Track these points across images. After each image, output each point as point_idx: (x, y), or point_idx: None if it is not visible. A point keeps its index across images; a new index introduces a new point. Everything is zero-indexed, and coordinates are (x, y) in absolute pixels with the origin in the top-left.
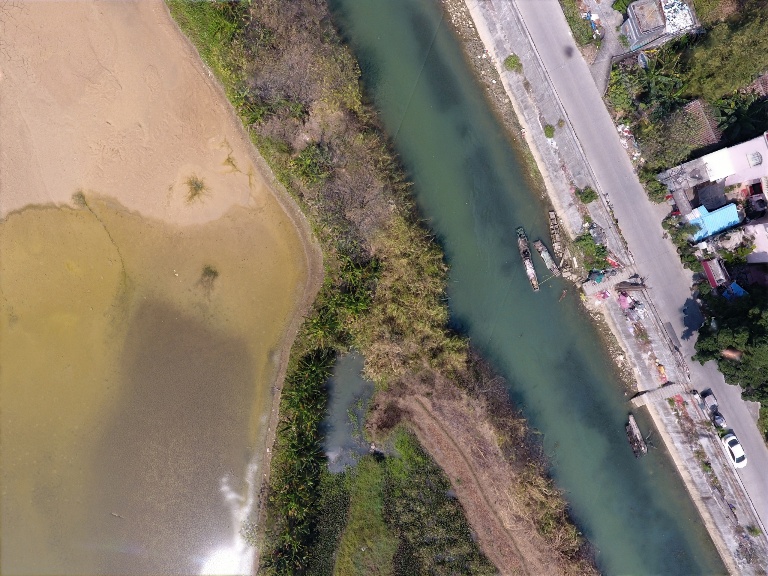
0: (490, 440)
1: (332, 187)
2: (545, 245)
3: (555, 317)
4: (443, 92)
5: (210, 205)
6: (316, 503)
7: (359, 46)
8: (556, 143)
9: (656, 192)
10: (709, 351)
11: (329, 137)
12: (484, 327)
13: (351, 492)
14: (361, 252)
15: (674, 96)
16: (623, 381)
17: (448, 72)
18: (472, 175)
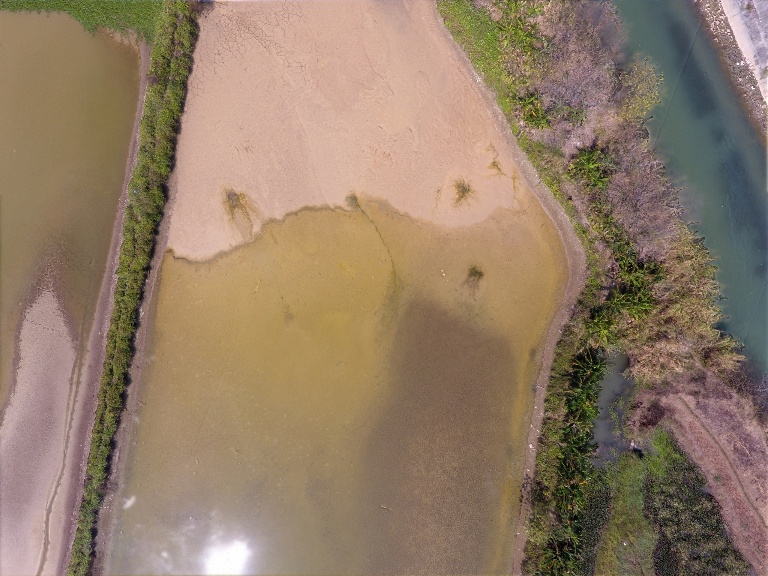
0: (758, 438)
1: None
2: None
3: None
4: (701, 98)
5: (476, 207)
6: None
7: None
8: None
9: None
10: None
11: (605, 142)
12: (740, 328)
13: (612, 488)
14: None
15: None
16: None
17: (705, 78)
18: (728, 179)
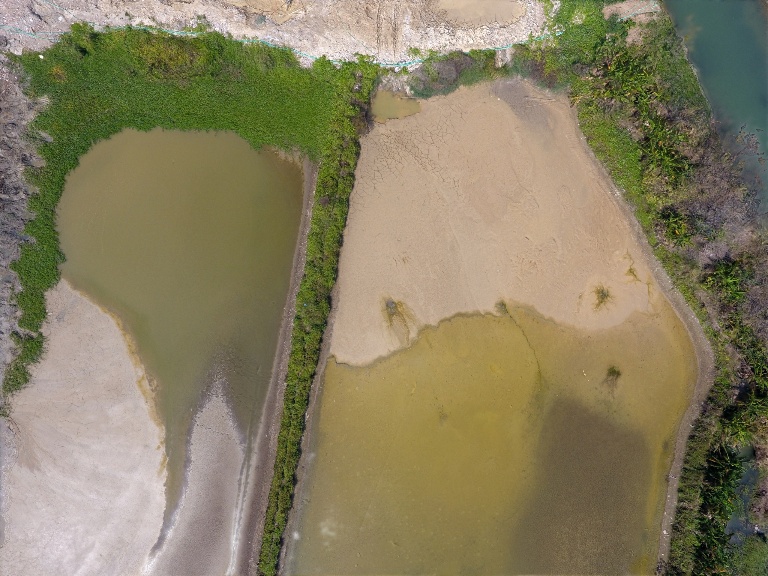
0: None
1: None
2: None
3: None
4: None
5: (614, 311)
6: None
7: (745, 168)
8: None
9: None
10: None
11: (738, 255)
12: None
13: (739, 569)
14: None
15: None
16: None
17: None
18: None
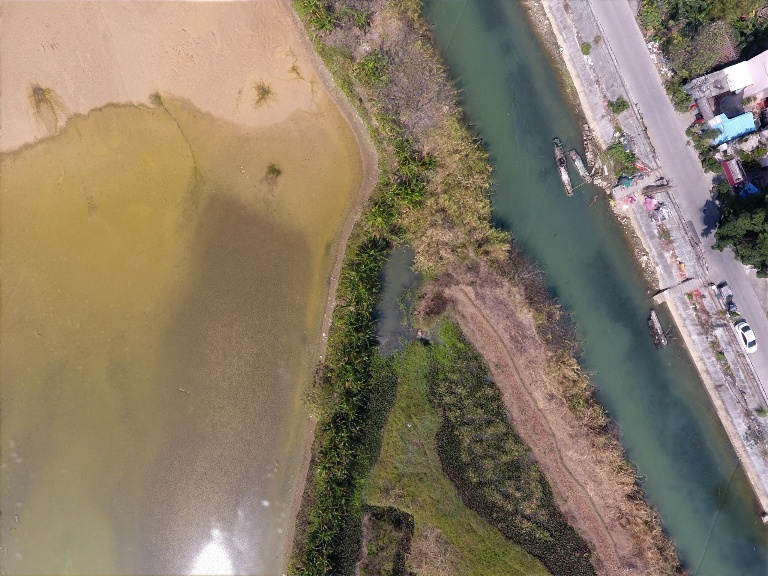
0: (528, 325)
1: (389, 93)
2: (579, 154)
3: (586, 220)
4: (489, 13)
5: (275, 109)
6: (367, 383)
7: None
8: (591, 60)
9: (682, 102)
10: (728, 236)
11: (388, 45)
12: (522, 227)
13: (399, 374)
14: (414, 153)
15: (699, 17)
16: (646, 280)
17: None
18: (514, 89)
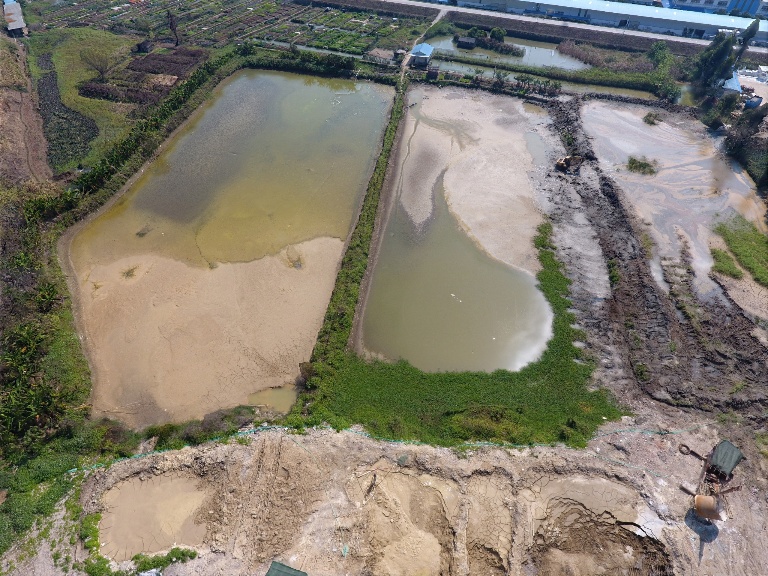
0: (4, 164)
1: None
2: None
3: None
4: None
5: (124, 265)
6: None
7: None
8: None
9: None
10: None
11: (0, 284)
12: None
13: None
14: None
15: None
16: None
17: None
18: None
